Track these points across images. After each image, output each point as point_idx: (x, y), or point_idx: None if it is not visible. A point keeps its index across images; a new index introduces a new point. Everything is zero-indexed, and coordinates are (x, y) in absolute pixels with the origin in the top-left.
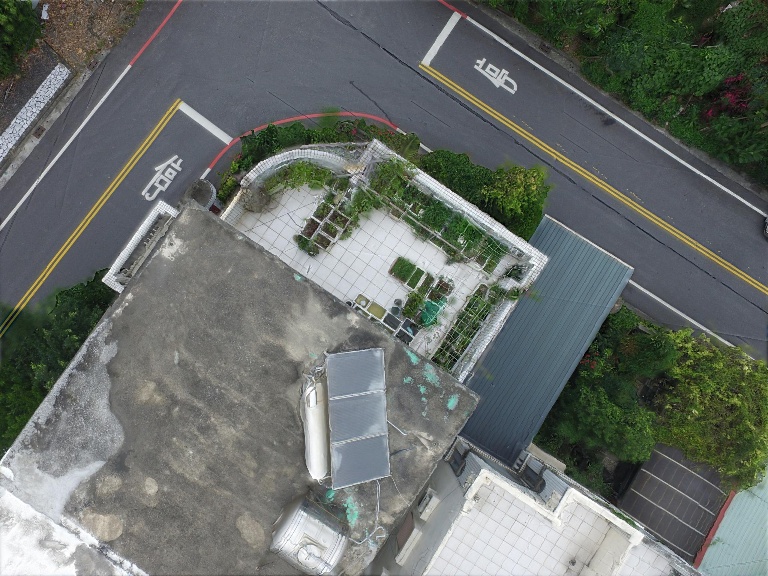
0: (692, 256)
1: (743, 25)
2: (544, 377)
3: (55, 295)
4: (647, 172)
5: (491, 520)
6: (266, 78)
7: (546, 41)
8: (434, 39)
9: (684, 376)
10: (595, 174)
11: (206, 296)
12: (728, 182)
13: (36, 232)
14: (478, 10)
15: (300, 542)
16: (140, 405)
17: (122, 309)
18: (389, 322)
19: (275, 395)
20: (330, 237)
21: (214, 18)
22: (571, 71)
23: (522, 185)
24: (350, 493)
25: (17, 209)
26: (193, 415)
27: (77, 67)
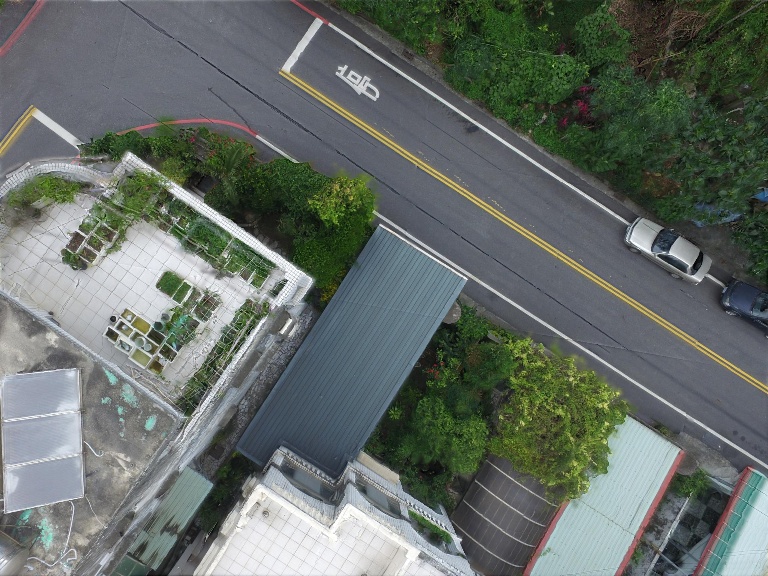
0: (554, 264)
1: (600, 33)
2: (373, 388)
3: None
4: (509, 180)
5: (282, 534)
6: (122, 84)
7: (408, 48)
8: (295, 46)
9: (521, 386)
10: (456, 182)
11: None
12: (591, 190)
13: None
14: (340, 16)
15: None
16: None
17: None
18: (155, 337)
19: None
20: (95, 251)
21: (69, 23)
22: (434, 78)
23: (338, 196)
24: (45, 515)
25: None
26: None
27: None
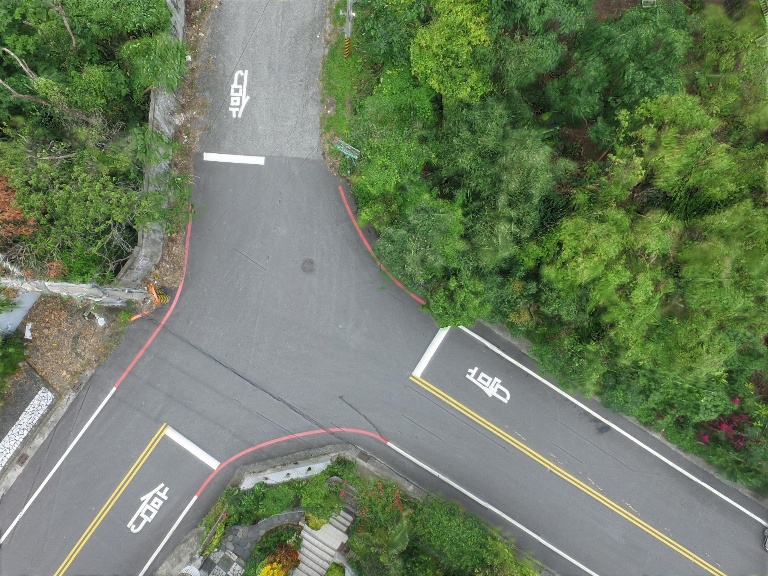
0: (690, 569)
1: (739, 345)
2: None
3: None
4: (643, 482)
5: None
6: (254, 398)
7: None
8: (425, 349)
9: None
10: (590, 486)
11: None
12: (726, 489)
13: (19, 570)
14: None
15: None
16: None
17: None
18: None
19: None
20: None
21: (200, 335)
22: None
23: None
24: None
25: None
26: None
27: (61, 390)
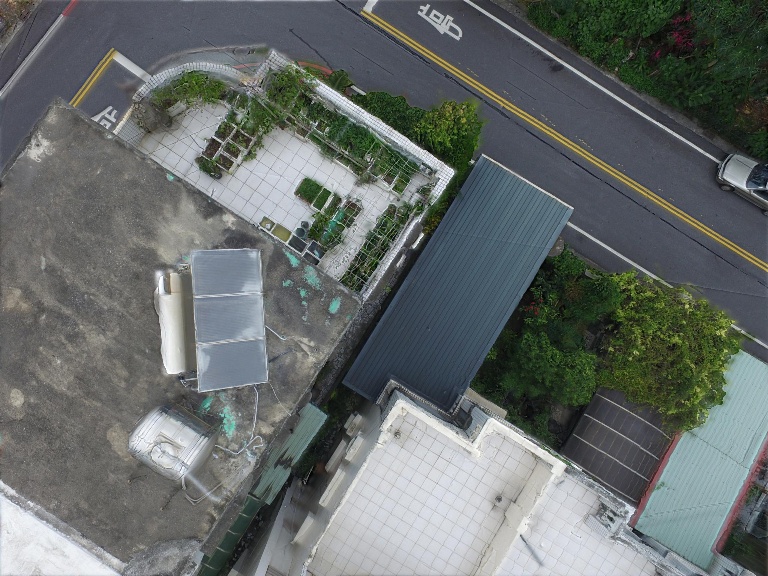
0: (643, 204)
1: None
2: (481, 320)
3: None
4: (596, 119)
5: (414, 456)
6: (202, 26)
7: None
8: None
9: (628, 319)
10: (543, 121)
11: (74, 198)
12: (680, 128)
13: None
14: None
15: (154, 440)
16: (4, 313)
17: None
18: (295, 245)
19: (147, 300)
20: (232, 157)
21: None
22: (517, 16)
23: (451, 118)
24: (227, 402)
25: None
26: (61, 323)
27: (7, 17)
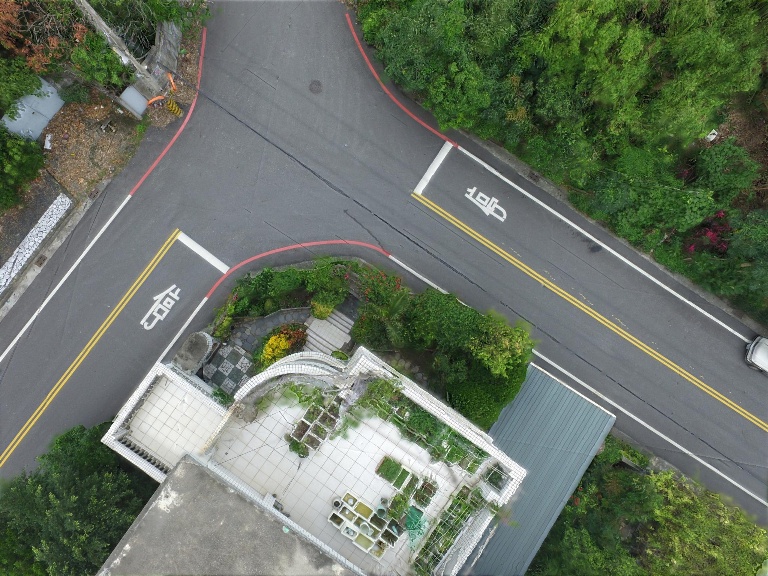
0: (675, 381)
1: (725, 162)
2: (528, 524)
3: (55, 423)
4: (632, 298)
5: None
6: (262, 208)
7: (535, 170)
8: (426, 168)
9: (664, 518)
10: (581, 300)
11: (199, 547)
12: (711, 308)
13: (37, 361)
14: (469, 139)
15: None
16: None
17: (120, 559)
18: (375, 521)
19: None
20: (320, 439)
21: (212, 149)
22: (559, 199)
23: (507, 350)
24: None
25: (19, 338)
26: None
27: (78, 197)
